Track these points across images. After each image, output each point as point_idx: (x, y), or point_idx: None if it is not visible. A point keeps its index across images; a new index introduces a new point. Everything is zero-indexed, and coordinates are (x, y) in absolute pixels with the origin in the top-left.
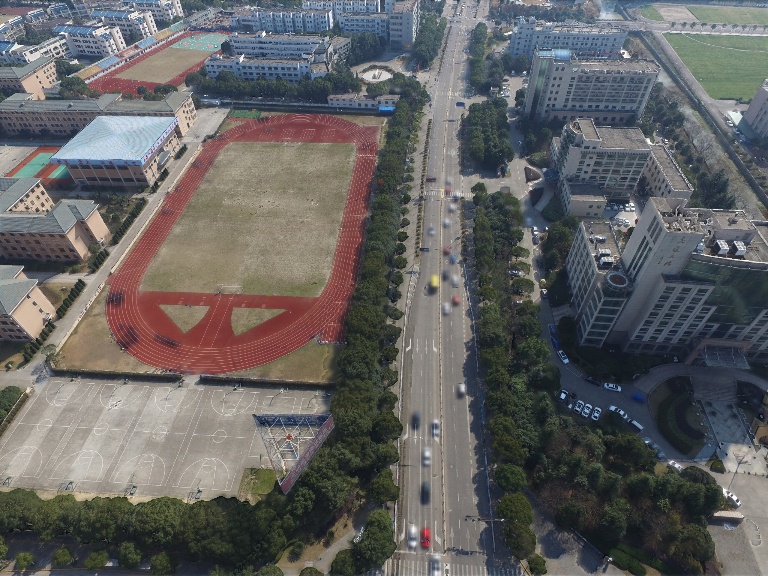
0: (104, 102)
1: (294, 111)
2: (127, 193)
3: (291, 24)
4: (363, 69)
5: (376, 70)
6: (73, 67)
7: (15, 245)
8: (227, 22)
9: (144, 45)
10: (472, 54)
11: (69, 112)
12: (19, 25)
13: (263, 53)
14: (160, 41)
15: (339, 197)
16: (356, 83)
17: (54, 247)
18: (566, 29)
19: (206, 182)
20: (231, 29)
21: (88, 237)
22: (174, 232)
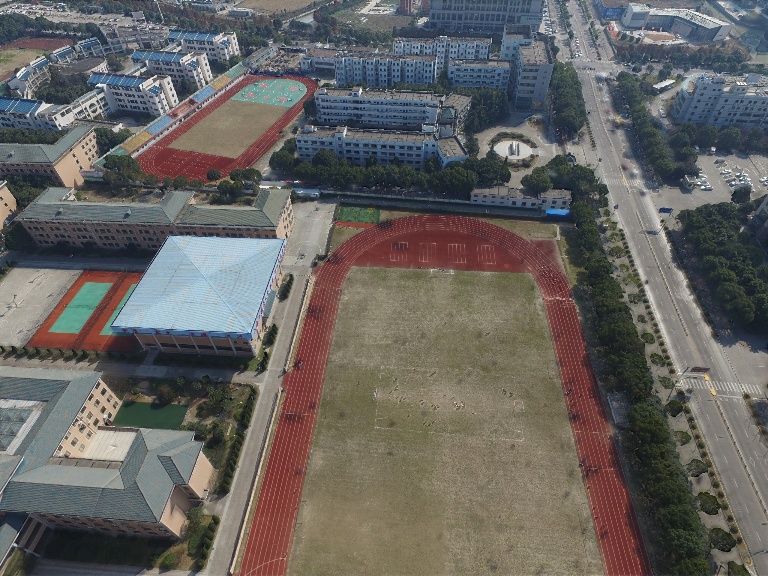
0: (174, 208)
1: (424, 211)
2: (223, 371)
3: (385, 73)
4: (492, 139)
5: (512, 142)
6: (118, 137)
7: (69, 520)
8: (293, 62)
9: (200, 98)
10: (623, 116)
11: (126, 224)
12: (42, 68)
13: (357, 114)
14: (218, 91)
15: (551, 388)
16: (508, 172)
17: (134, 526)
18: (763, 90)
19: (337, 350)
20: (302, 73)
21: (186, 495)
22: (314, 466)
